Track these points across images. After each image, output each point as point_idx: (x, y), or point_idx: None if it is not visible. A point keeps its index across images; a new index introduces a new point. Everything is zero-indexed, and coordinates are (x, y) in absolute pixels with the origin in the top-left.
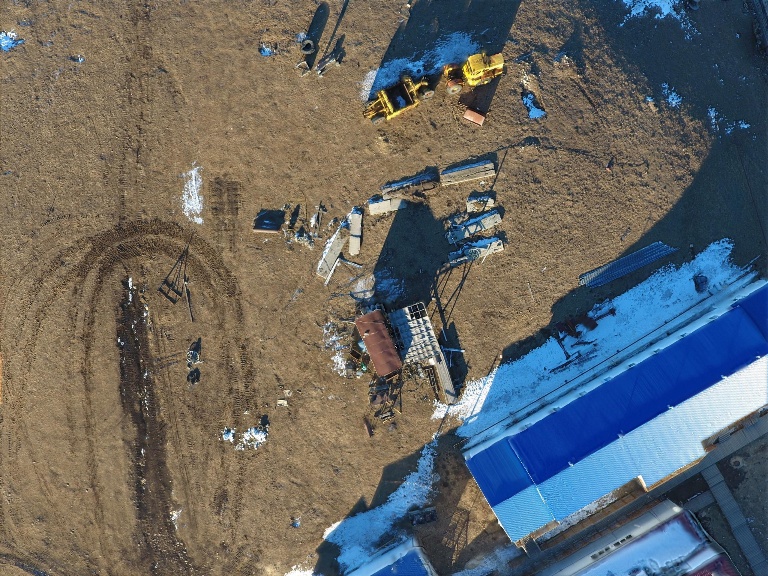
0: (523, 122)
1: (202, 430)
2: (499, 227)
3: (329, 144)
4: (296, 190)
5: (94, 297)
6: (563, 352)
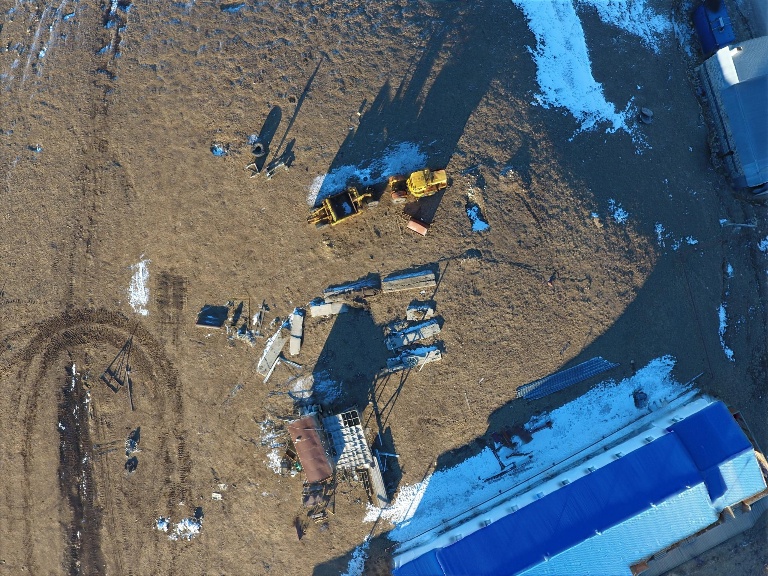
0: (466, 234)
1: (137, 518)
2: (438, 336)
3: (274, 245)
4: (240, 288)
5: (38, 381)
6: (498, 463)
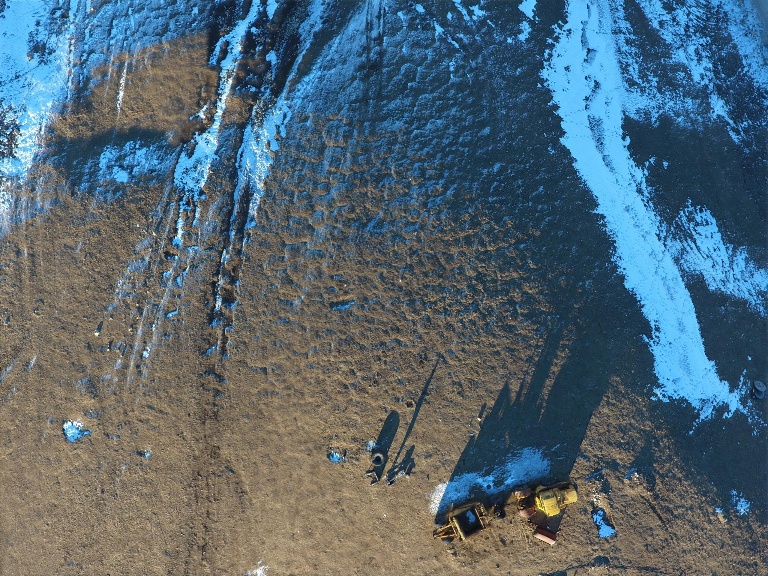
0: (593, 542)
1: None
2: None
3: (397, 552)
4: None
5: None
6: None
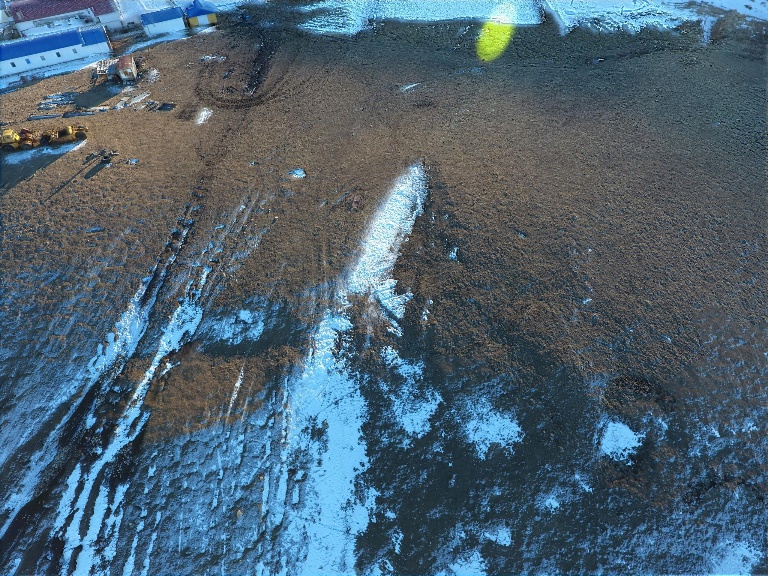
0: (3, 130)
1: None
2: None
3: None
4: None
5: None
6: None
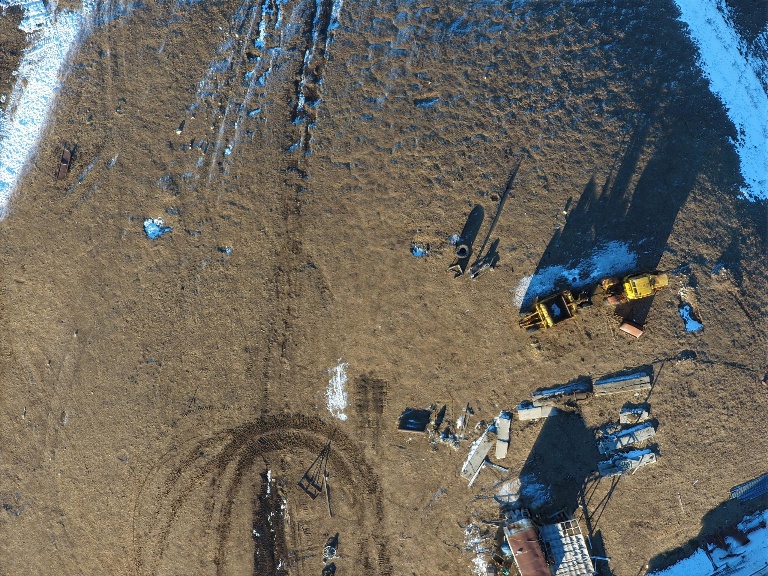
0: (680, 335)
1: None
2: (652, 439)
3: (479, 348)
4: (443, 391)
5: (232, 489)
6: (711, 564)
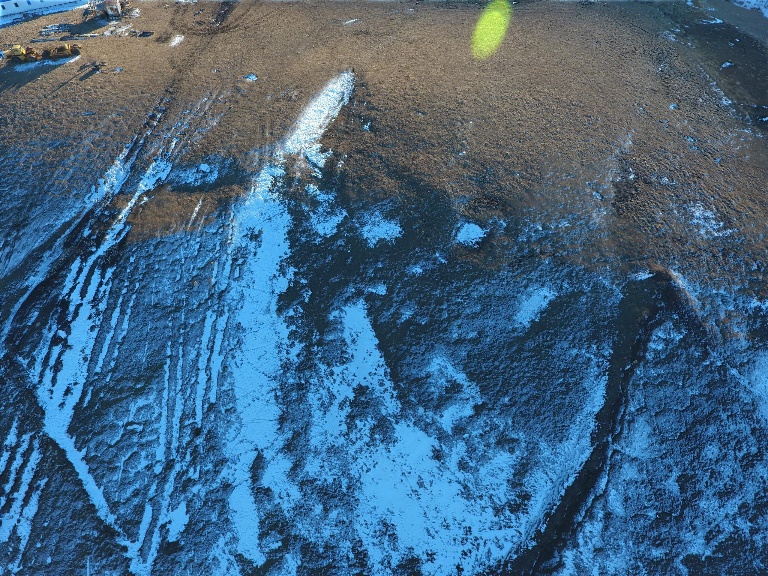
0: None
1: None
2: None
3: None
4: None
5: None
6: None
